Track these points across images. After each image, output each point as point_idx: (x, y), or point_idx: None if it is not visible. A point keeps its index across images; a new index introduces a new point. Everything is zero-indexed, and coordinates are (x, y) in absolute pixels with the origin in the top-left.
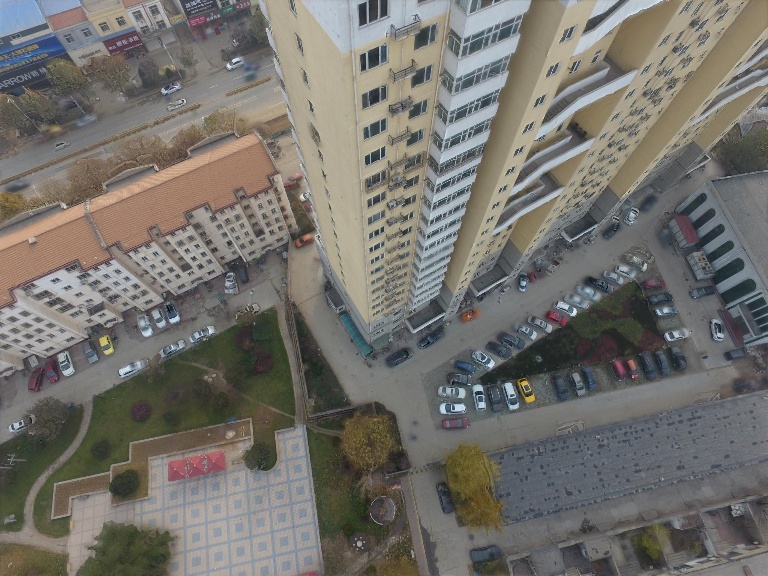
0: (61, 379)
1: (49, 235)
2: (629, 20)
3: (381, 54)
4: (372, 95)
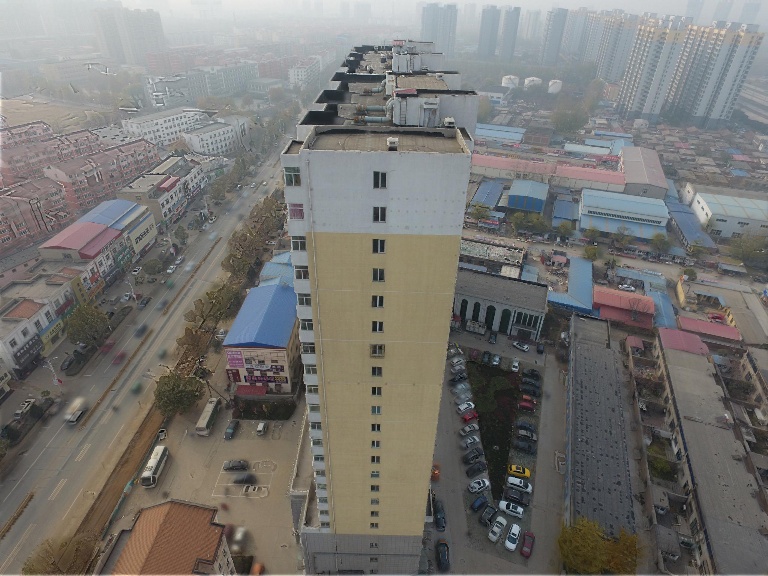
0: None
1: None
2: None
3: None
4: None
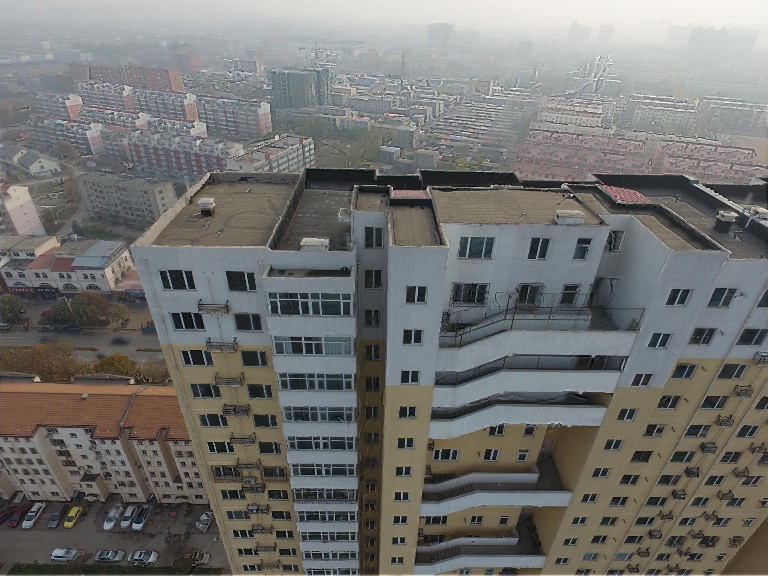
0: (18, 528)
1: (98, 397)
2: (561, 431)
3: (206, 357)
4: (204, 388)
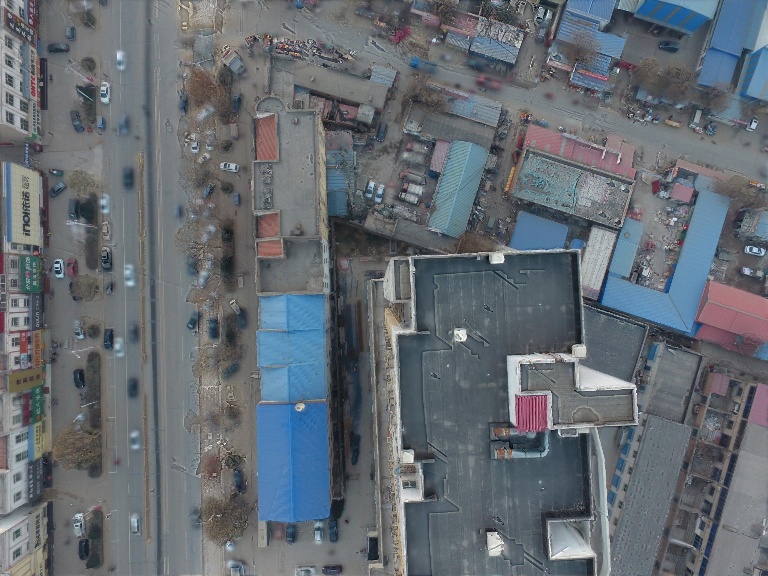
0: None
1: None
2: None
3: None
4: None
